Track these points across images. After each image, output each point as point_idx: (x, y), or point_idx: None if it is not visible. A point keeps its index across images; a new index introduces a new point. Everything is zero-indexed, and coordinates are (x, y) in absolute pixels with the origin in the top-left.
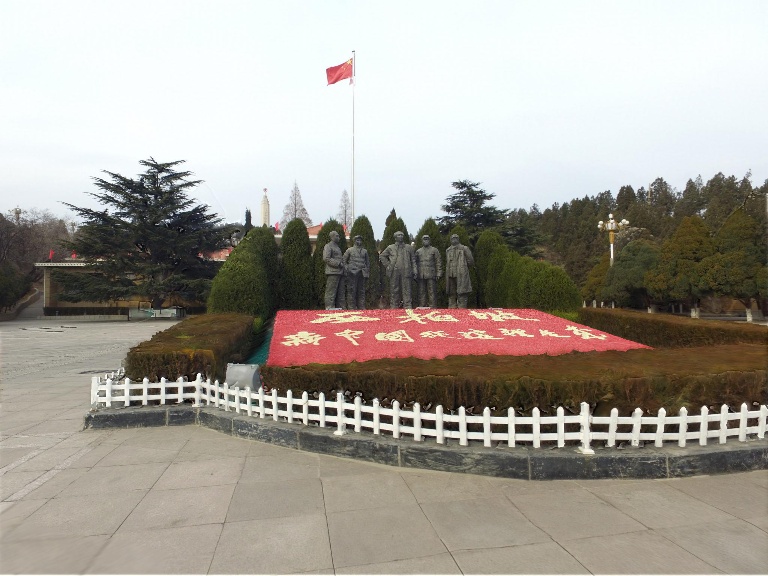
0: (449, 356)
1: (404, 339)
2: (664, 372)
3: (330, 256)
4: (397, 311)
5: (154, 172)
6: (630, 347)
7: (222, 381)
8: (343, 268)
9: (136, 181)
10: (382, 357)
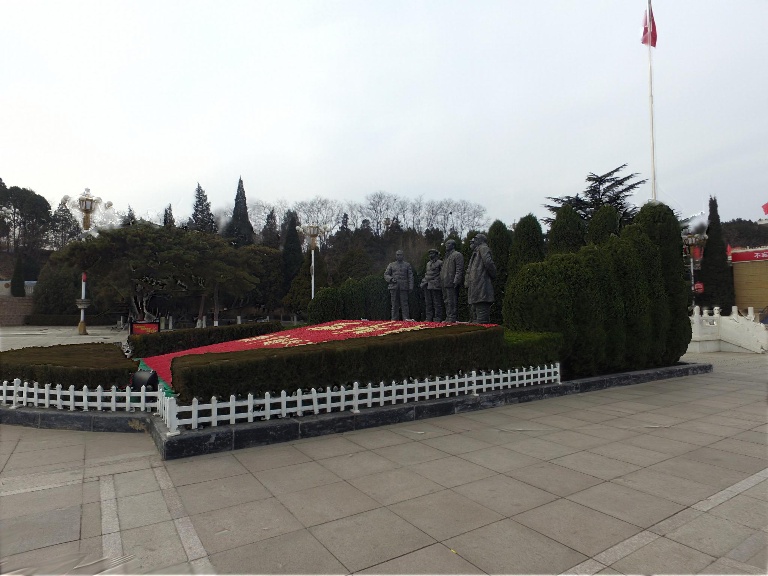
0: (108, 345)
1: (270, 343)
2: (3, 354)
3: (388, 274)
4: None
5: (597, 185)
6: None
7: (158, 352)
8: (399, 283)
9: (573, 199)
10: (215, 351)
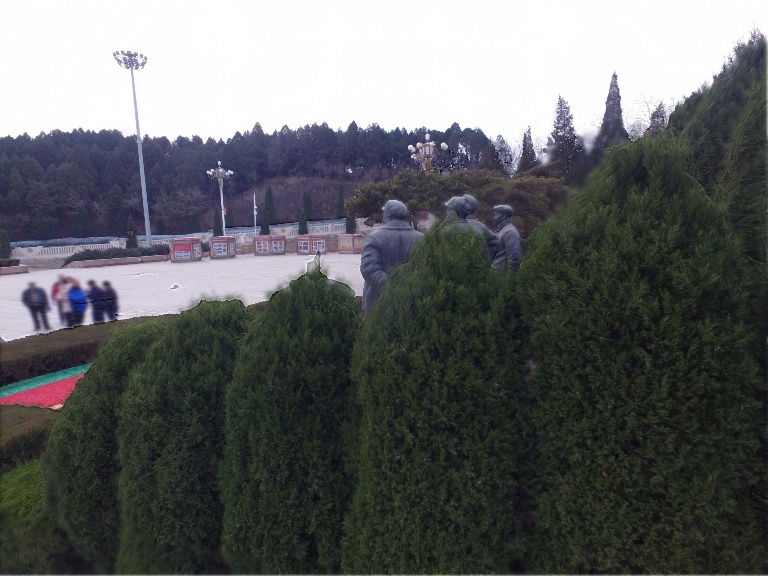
0: None
1: None
2: None
3: None
4: None
5: None
6: (25, 405)
7: None
8: None
9: None
10: None
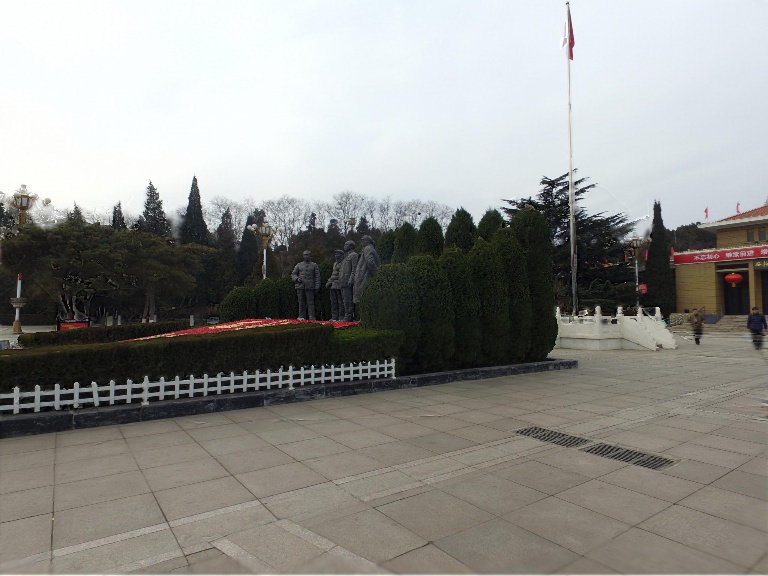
0: None
1: None
2: None
3: (295, 273)
4: (274, 321)
5: (550, 188)
6: None
7: None
8: (304, 283)
9: (527, 202)
10: None
